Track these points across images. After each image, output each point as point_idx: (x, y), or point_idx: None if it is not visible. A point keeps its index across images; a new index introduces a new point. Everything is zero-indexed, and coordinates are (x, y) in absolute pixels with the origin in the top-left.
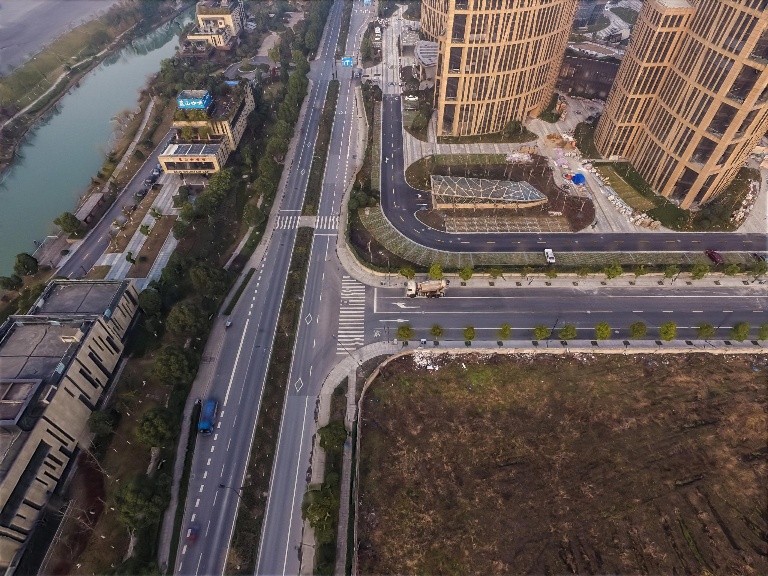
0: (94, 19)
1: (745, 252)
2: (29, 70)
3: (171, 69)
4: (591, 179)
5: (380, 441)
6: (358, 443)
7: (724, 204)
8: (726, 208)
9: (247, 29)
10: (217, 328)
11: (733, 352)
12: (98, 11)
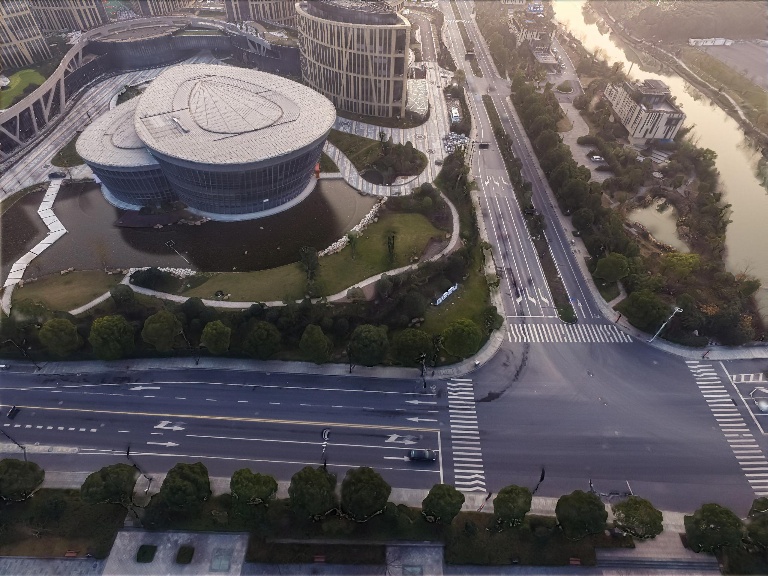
0: None
1: None
2: (748, 87)
3: None
4: None
5: None
6: None
7: None
8: None
9: (631, 145)
10: None
11: None
12: None
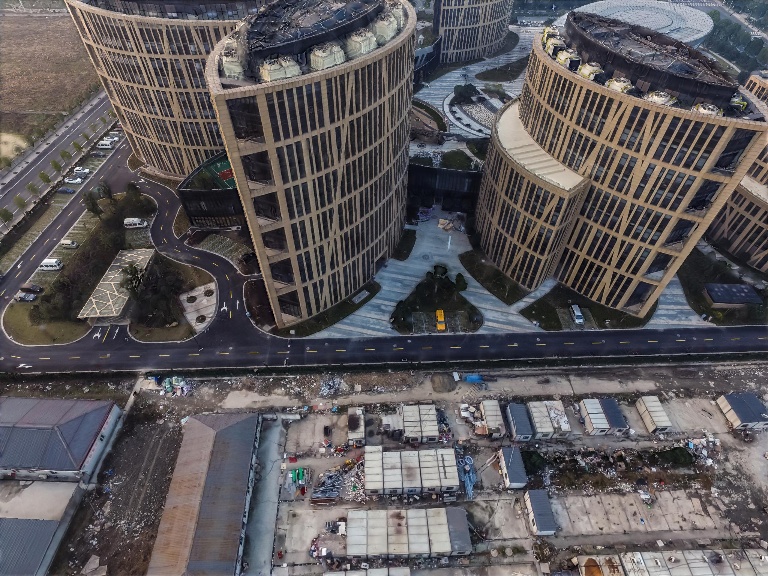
0: None
1: None
2: None
3: None
4: None
5: None
6: None
7: None
8: None
9: None
10: None
11: None
12: None
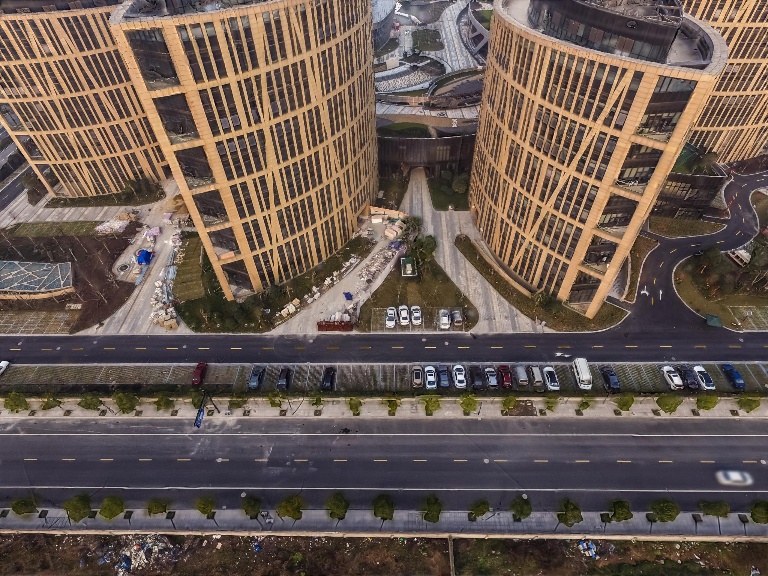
0: None
1: (250, 364)
2: None
3: None
4: (165, 256)
5: None
6: None
7: (269, 295)
8: (275, 299)
9: None
10: None
11: (78, 533)
12: None
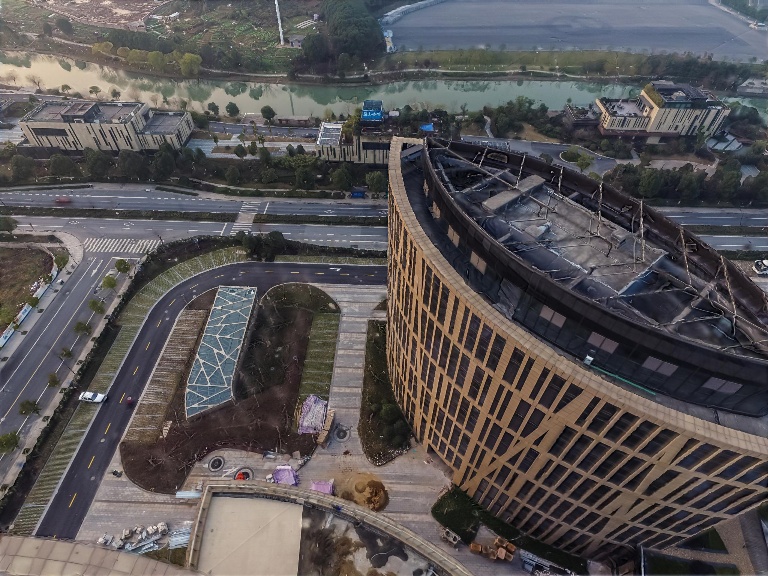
0: (646, 54)
1: None
2: None
3: (521, 108)
4: None
5: (2, 256)
6: (2, 242)
7: None
8: None
9: (708, 144)
10: (147, 186)
11: None
12: (661, 50)
